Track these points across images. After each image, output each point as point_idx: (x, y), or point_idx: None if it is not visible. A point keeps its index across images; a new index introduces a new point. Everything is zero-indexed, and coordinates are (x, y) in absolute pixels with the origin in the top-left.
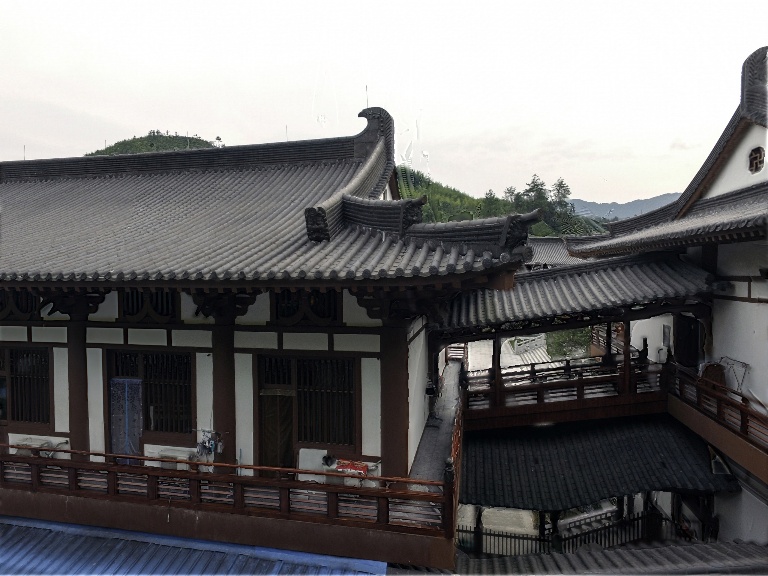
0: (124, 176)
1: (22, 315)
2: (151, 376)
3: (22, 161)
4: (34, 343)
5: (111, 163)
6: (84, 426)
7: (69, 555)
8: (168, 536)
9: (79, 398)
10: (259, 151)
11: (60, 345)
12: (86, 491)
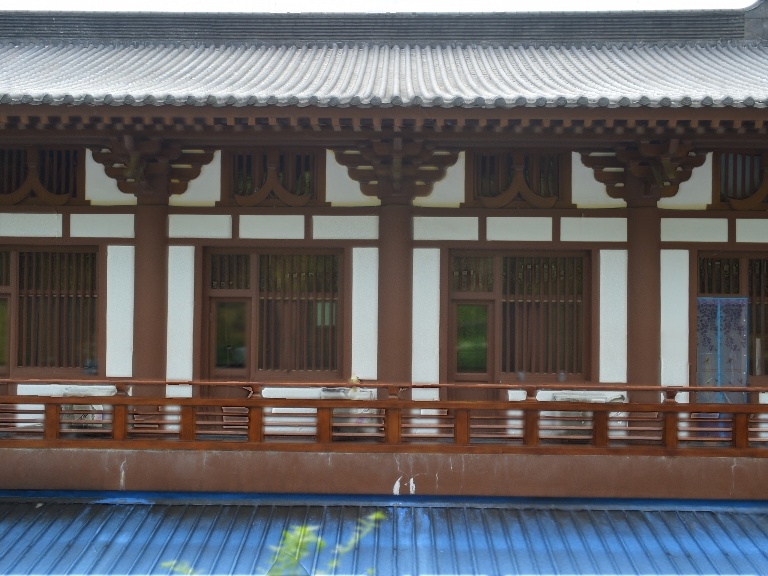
0: (366, 46)
1: (540, 200)
2: (759, 292)
3: (168, 12)
4: (565, 243)
5: (342, 24)
6: (656, 370)
7: None
8: None
9: (653, 326)
10: (597, 21)
11: (613, 246)
12: (765, 448)
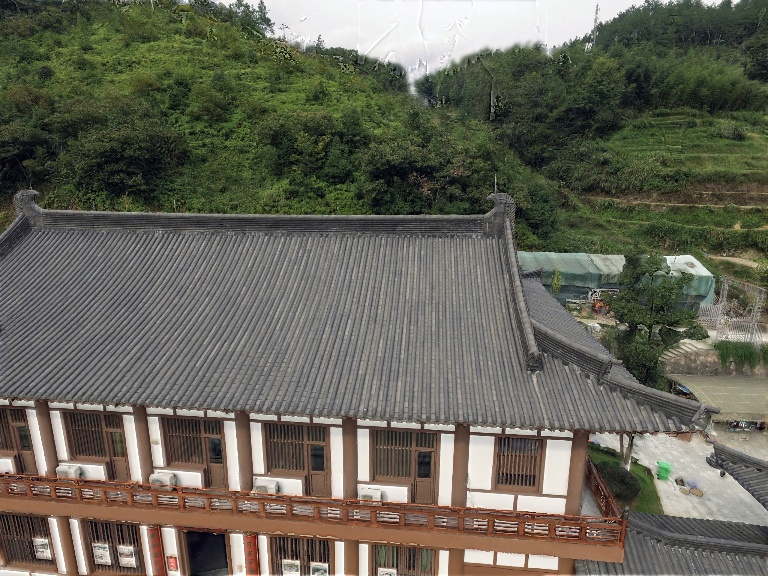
0: None
1: None
2: None
3: None
4: None
5: None
6: None
7: None
8: None
9: None
10: None
11: None
12: None
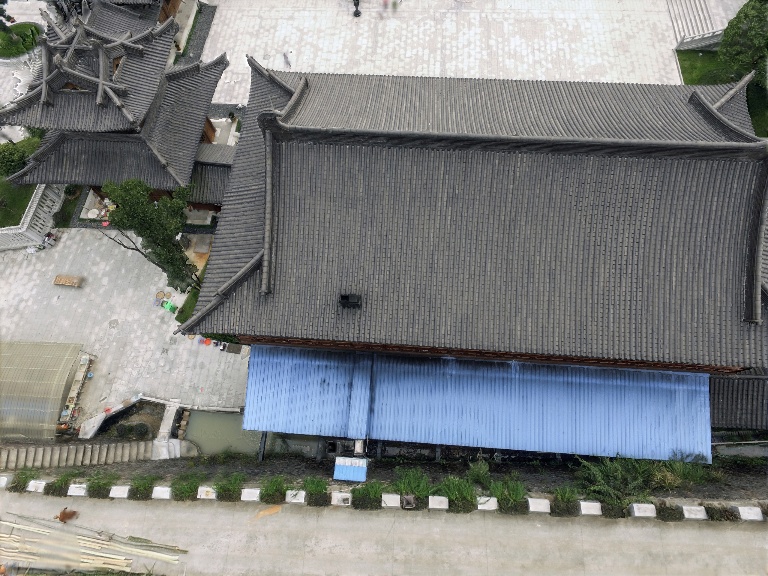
0: (534, 154)
1: None
2: None
3: (428, 135)
4: None
5: (524, 145)
6: None
7: (600, 377)
8: (631, 368)
9: None
10: (667, 149)
11: None
12: (603, 363)
